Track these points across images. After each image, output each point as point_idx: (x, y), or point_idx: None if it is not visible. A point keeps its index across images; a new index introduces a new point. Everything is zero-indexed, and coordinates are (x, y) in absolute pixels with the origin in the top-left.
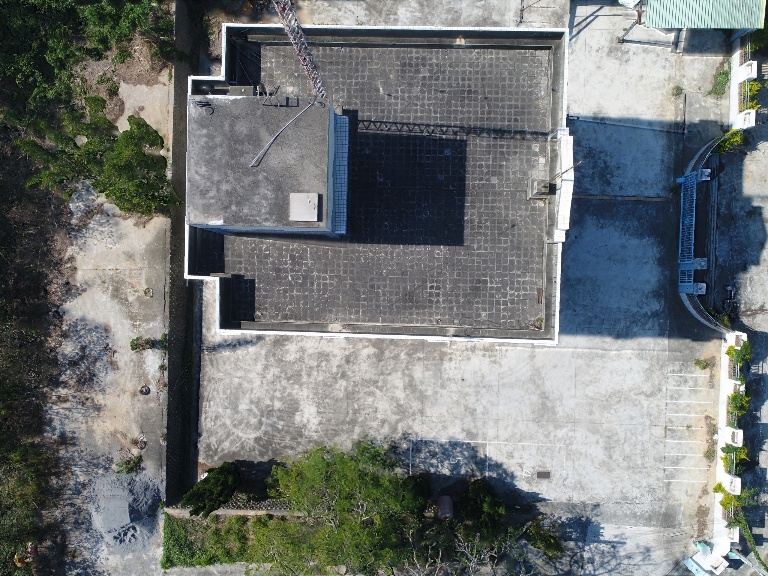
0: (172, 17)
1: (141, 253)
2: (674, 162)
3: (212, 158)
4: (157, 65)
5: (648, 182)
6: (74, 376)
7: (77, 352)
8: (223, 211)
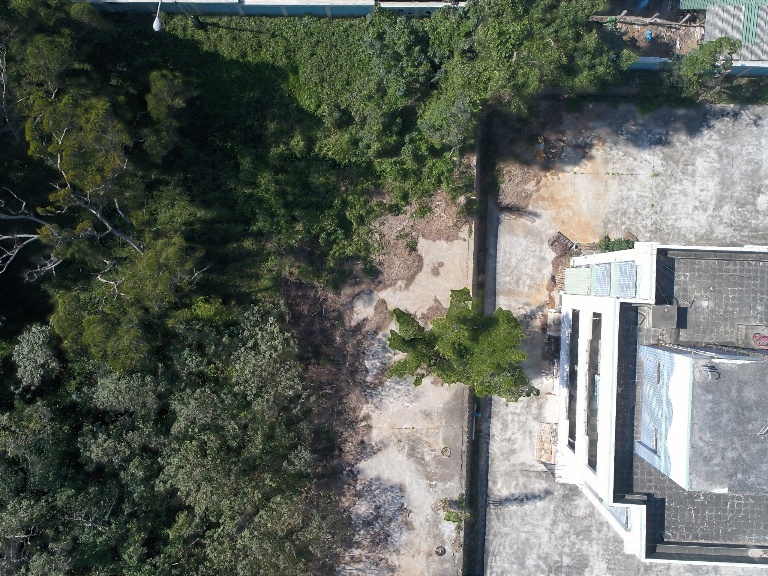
0: (473, 171)
1: (439, 412)
2: None
3: (718, 424)
4: (460, 222)
5: None
6: (368, 536)
7: (371, 512)
8: (728, 479)
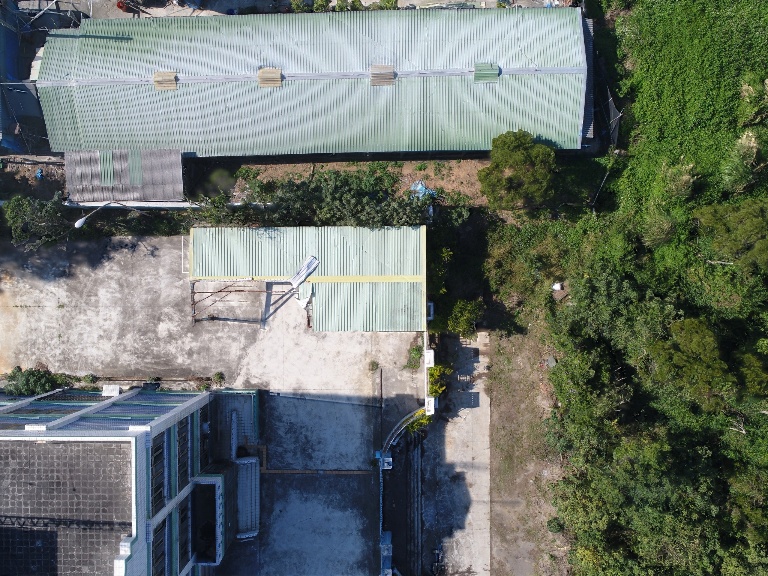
0: None
1: None
2: (373, 435)
3: None
4: None
5: (349, 455)
6: None
7: None
8: None
